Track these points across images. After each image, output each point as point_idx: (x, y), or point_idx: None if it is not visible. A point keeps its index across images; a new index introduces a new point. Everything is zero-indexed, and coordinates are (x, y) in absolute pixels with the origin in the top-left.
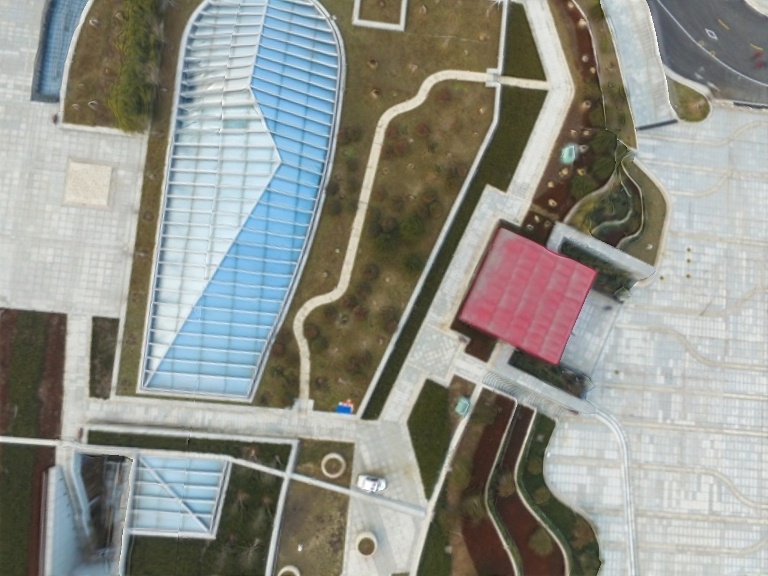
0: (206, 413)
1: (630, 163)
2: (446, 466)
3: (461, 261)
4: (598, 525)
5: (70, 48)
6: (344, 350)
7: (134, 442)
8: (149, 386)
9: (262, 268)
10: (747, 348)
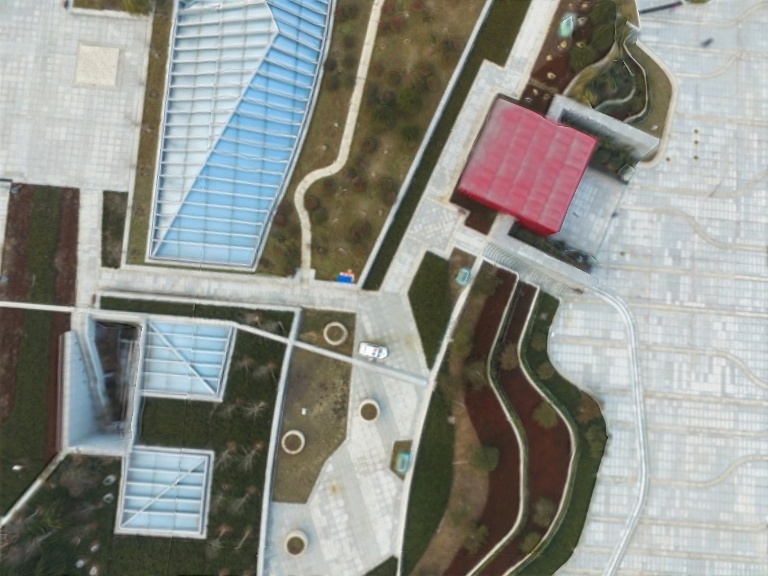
0: (212, 283)
1: (633, 45)
2: (447, 336)
3: (459, 135)
4: (605, 404)
5: None
6: (344, 220)
7: (144, 308)
8: (157, 255)
9: (263, 141)
10: (760, 230)
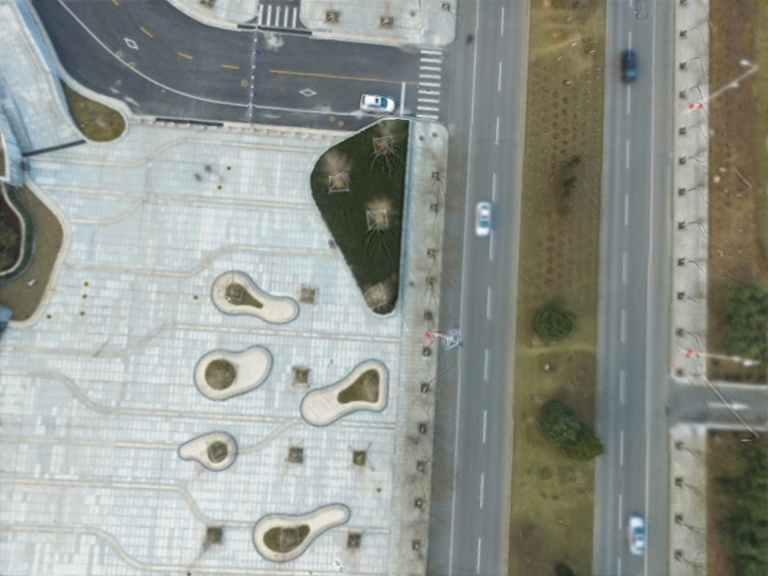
0: None
1: (19, 191)
2: None
3: None
4: None
5: None
6: None
7: None
8: None
9: None
10: (149, 391)
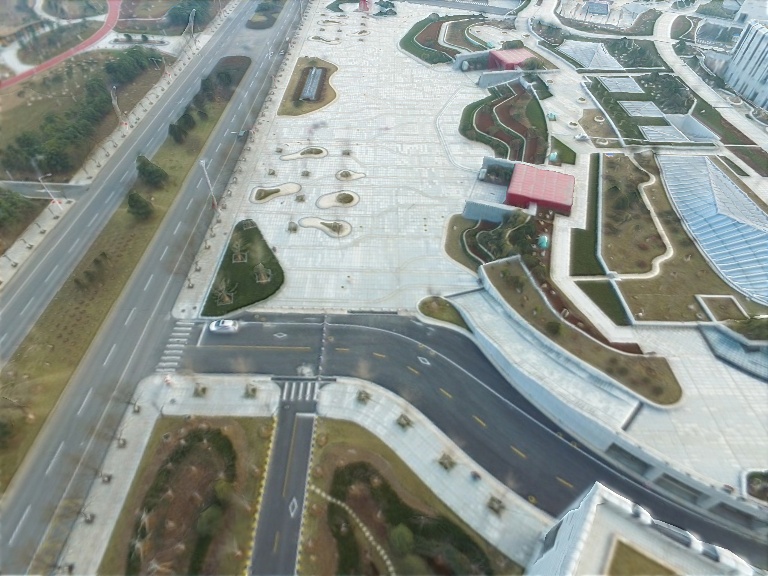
0: None
1: None
2: (549, 143)
3: (581, 201)
4: None
5: None
6: None
7: None
8: None
9: None
10: (383, 193)
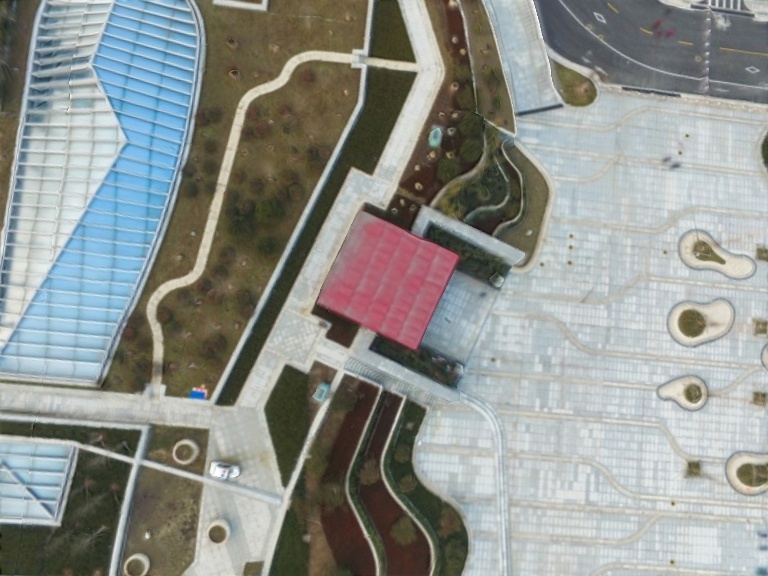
0: (55, 398)
1: (512, 148)
2: (304, 453)
3: (324, 245)
4: (469, 515)
5: None
6: (197, 334)
7: None
8: None
9: (112, 251)
10: (629, 336)
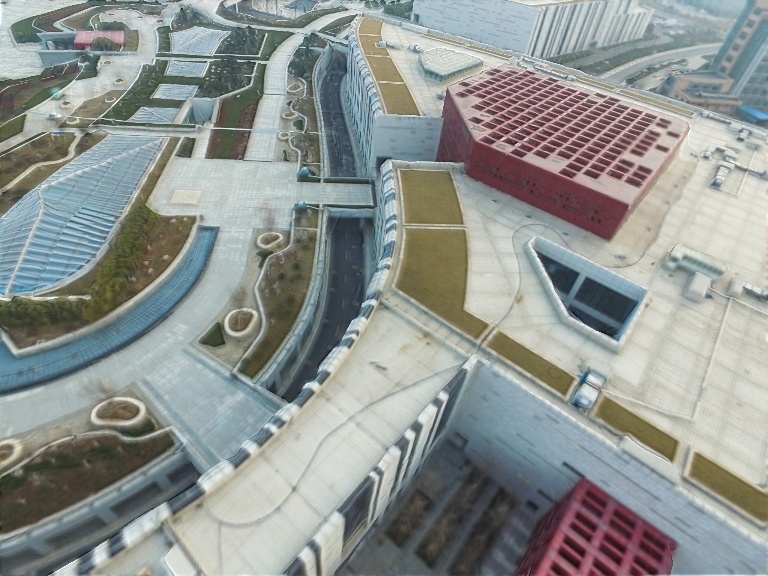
0: None
1: None
2: None
3: None
4: None
5: (187, 246)
6: None
7: (173, 125)
8: None
9: None
10: None
